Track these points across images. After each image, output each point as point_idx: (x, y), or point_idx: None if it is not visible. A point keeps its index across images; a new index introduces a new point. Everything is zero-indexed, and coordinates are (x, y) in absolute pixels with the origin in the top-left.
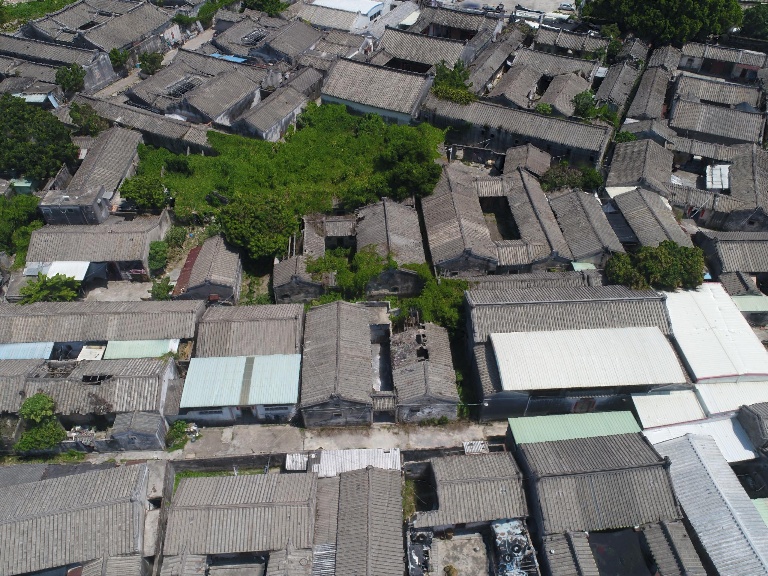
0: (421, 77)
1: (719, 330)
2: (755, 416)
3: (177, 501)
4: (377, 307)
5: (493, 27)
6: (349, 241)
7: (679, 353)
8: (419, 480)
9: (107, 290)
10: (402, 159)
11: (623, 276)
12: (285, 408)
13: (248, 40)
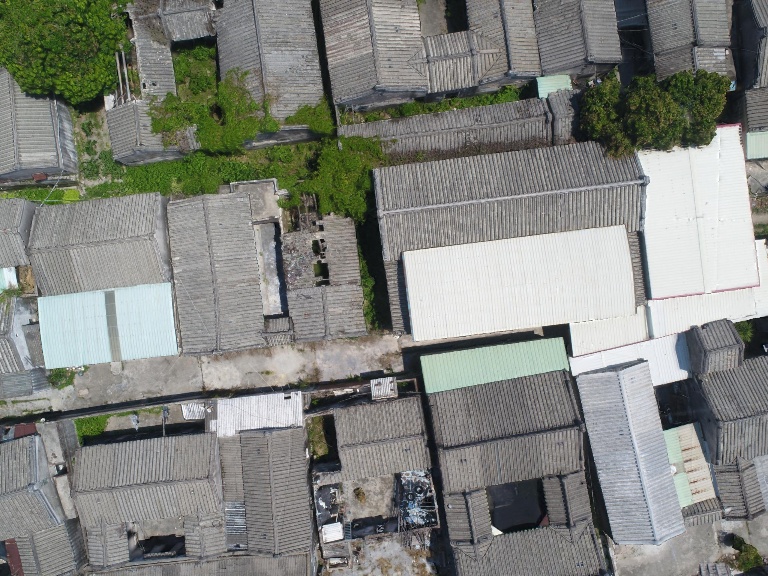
0: None
1: (706, 220)
2: (702, 350)
3: (78, 483)
4: (260, 184)
5: None
6: None
7: (643, 255)
8: None
9: None
10: None
11: (600, 131)
12: None
13: None
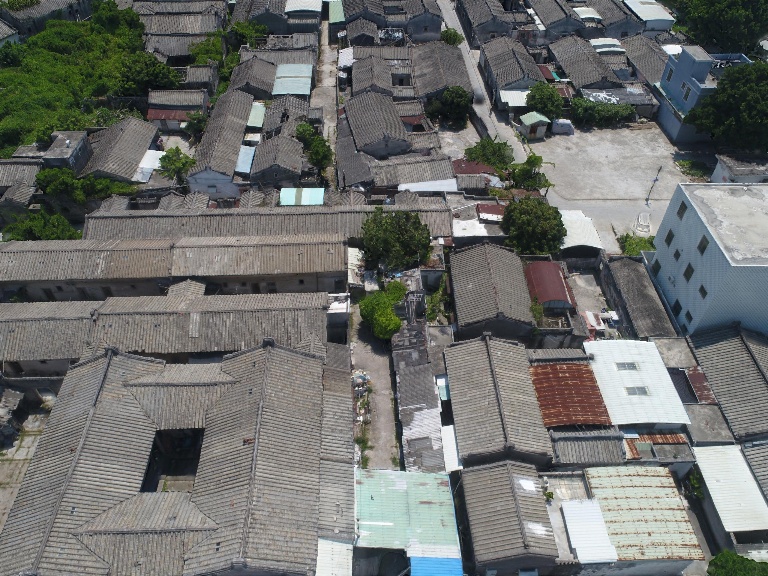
0: None
1: None
2: None
3: None
4: None
5: None
6: None
7: None
8: None
9: None
10: None
11: None
12: None
13: None
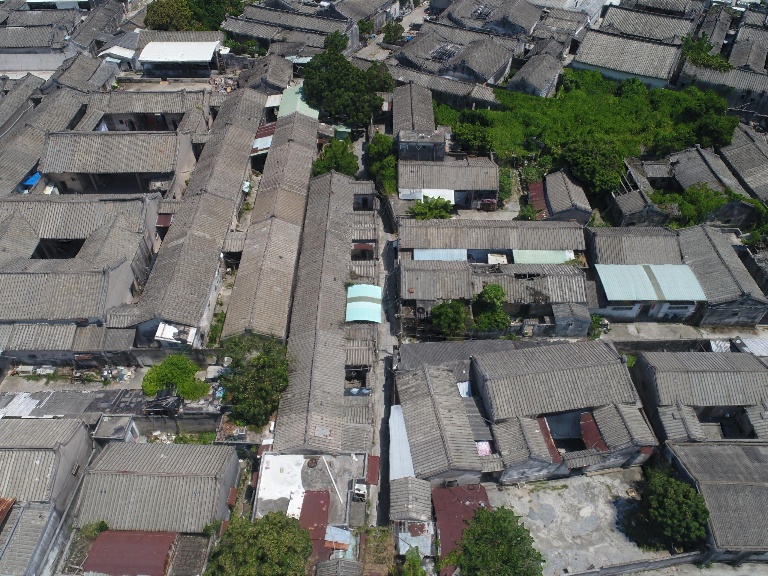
0: (673, 47)
1: None
2: None
3: None
4: (725, 233)
5: (701, 8)
6: (660, 183)
7: None
8: None
9: (460, 217)
10: (707, 112)
11: None
12: (685, 308)
13: (479, 15)
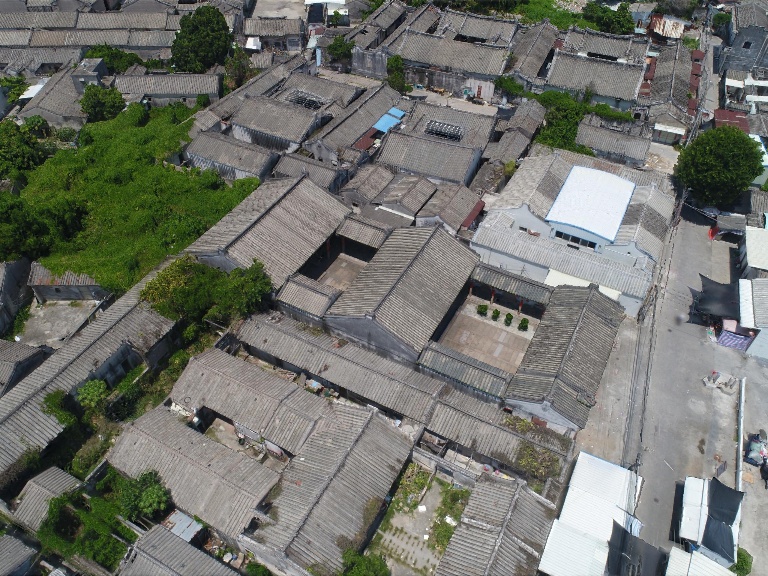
0: None
1: None
2: None
3: None
4: None
5: None
6: None
7: None
8: None
9: None
10: None
11: None
12: None
13: None
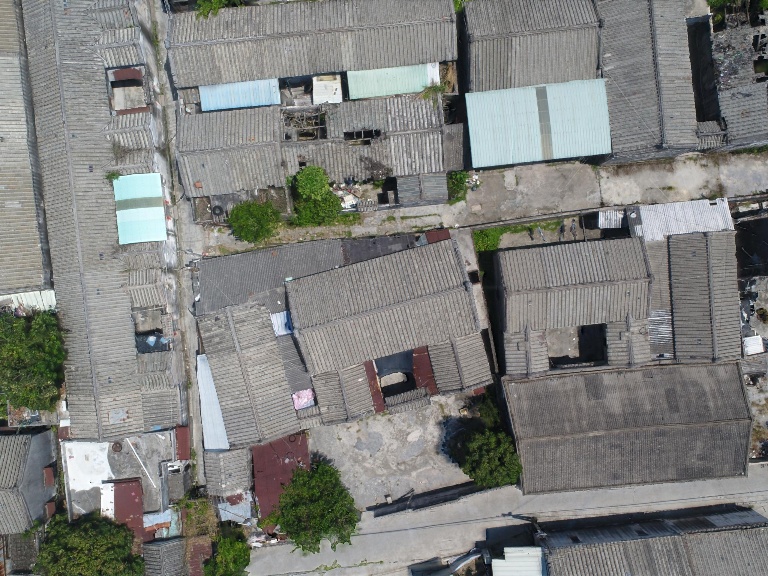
0: None
1: None
2: None
3: (509, 284)
4: None
5: None
6: None
7: None
8: (737, 226)
9: None
10: None
11: None
12: None
13: None
